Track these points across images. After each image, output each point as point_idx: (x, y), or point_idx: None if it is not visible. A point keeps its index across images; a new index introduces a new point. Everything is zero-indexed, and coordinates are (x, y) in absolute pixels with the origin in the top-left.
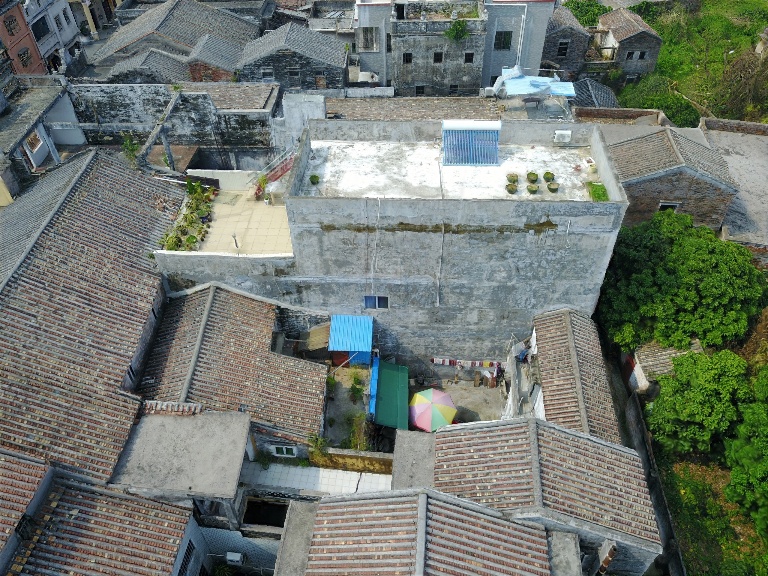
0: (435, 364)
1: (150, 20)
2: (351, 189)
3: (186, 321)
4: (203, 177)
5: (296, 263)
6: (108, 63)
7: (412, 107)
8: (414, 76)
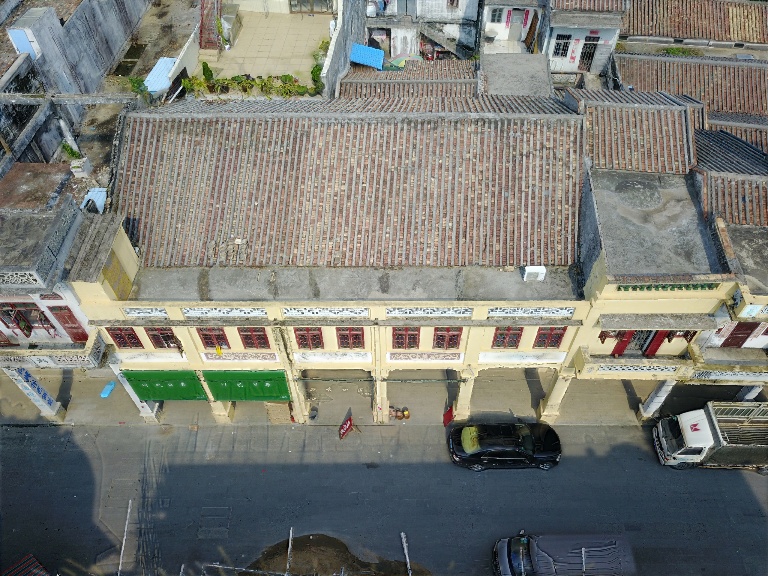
0: None
1: None
2: None
3: None
4: (179, 74)
5: None
6: None
7: None
8: None
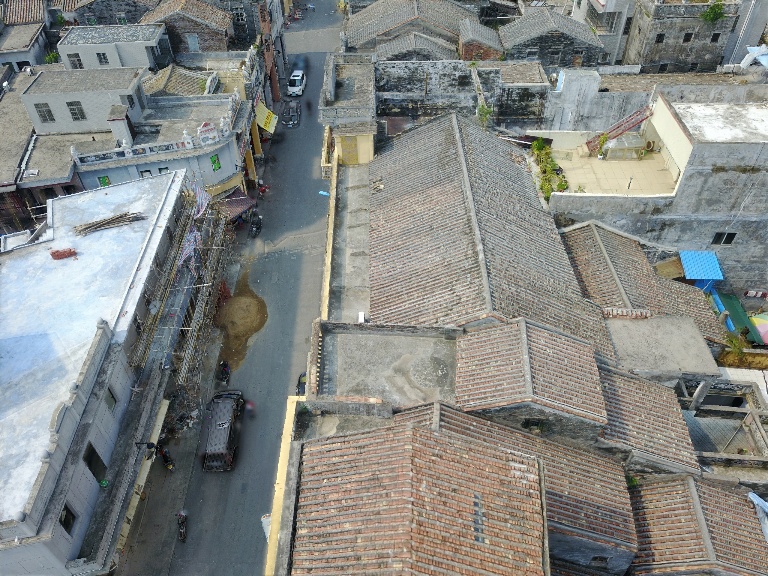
0: (746, 297)
1: (394, 8)
2: (719, 140)
3: (580, 252)
4: (539, 137)
5: (673, 202)
6: (368, 46)
7: (662, 82)
8: (662, 55)
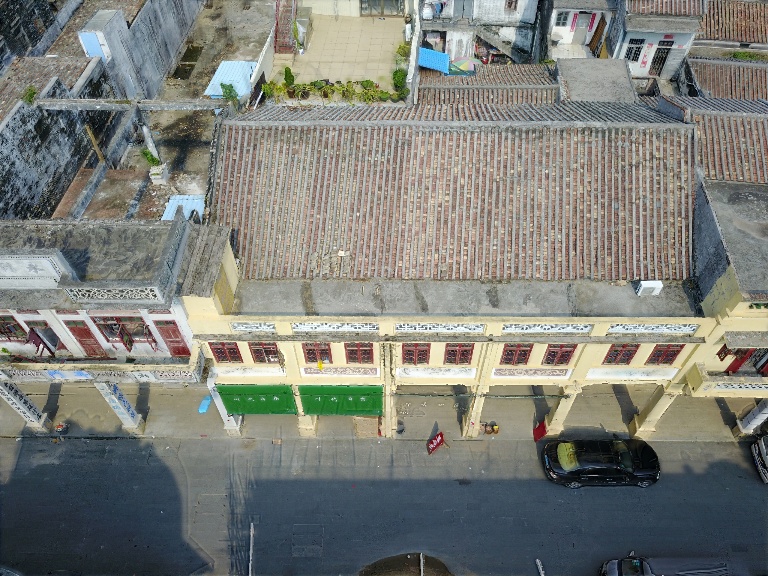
0: None
1: None
2: None
3: None
4: (259, 79)
5: None
6: None
7: None
8: None
